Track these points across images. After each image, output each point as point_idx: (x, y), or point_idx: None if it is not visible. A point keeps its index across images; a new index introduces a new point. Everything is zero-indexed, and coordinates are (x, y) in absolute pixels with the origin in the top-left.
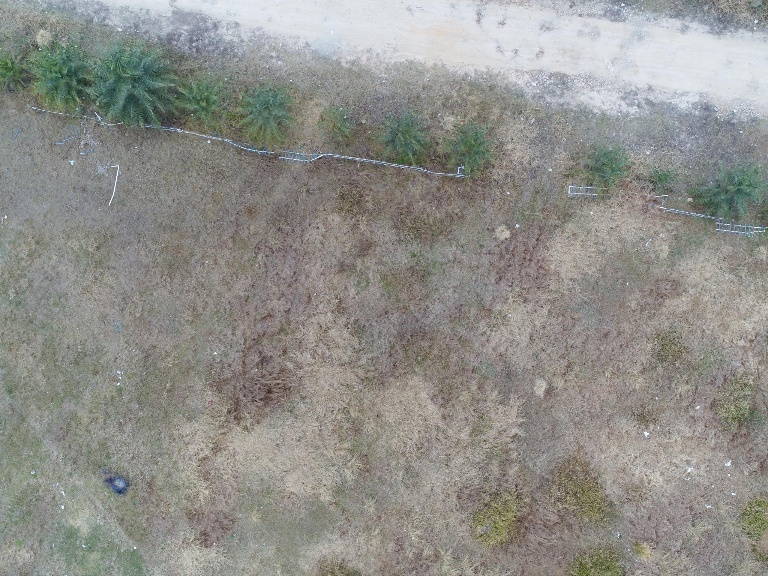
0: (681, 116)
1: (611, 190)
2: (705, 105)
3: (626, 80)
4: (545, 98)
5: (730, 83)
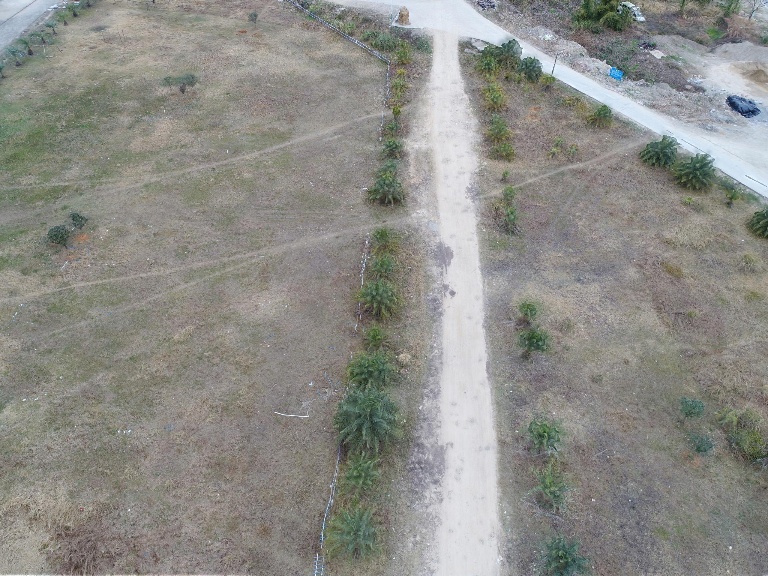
0: None
1: None
2: None
3: None
4: None
5: None
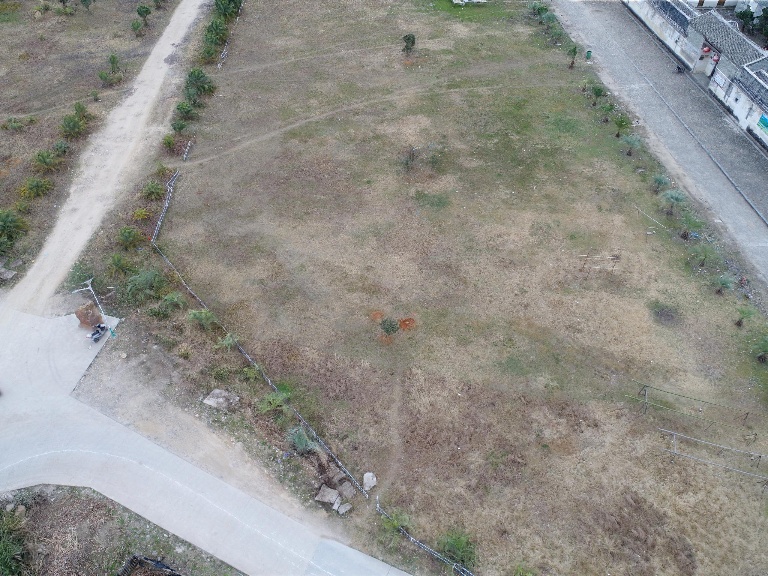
0: None
1: None
2: None
3: None
4: None
5: None
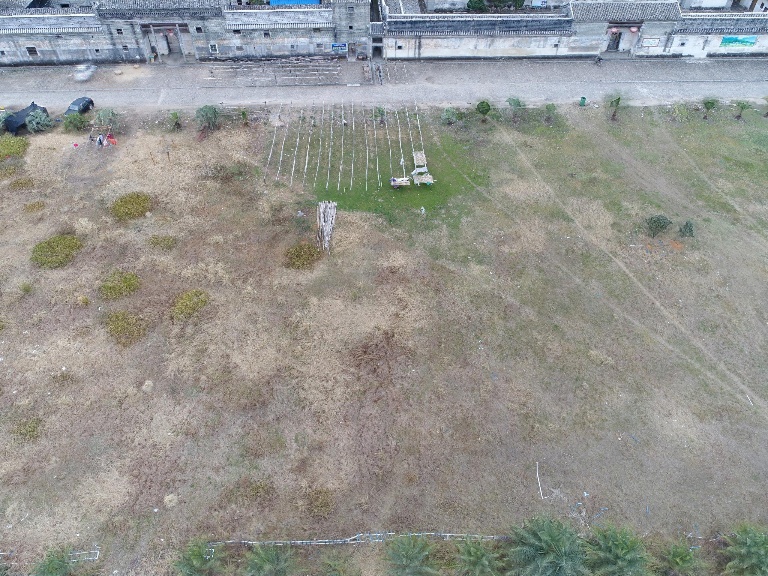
0: None
1: None
2: None
3: None
4: None
5: None
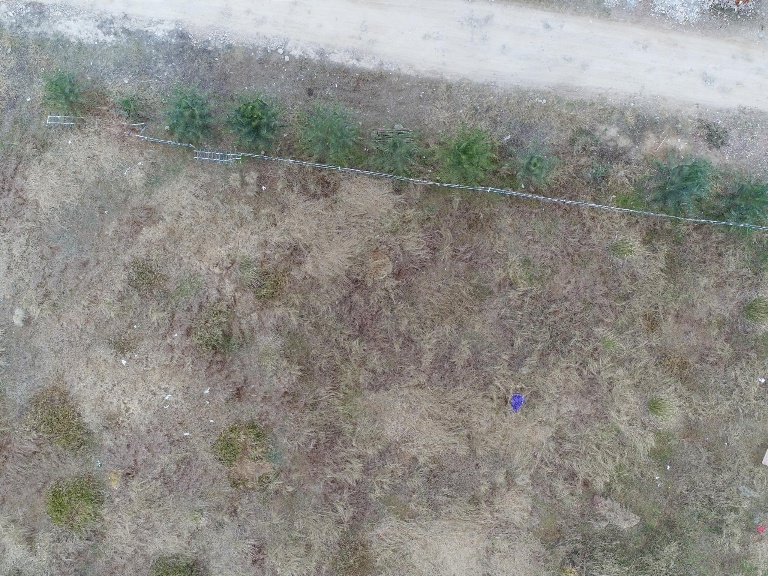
0: (157, 44)
1: (86, 119)
2: (181, 33)
3: (102, 9)
4: (22, 28)
5: (204, 10)
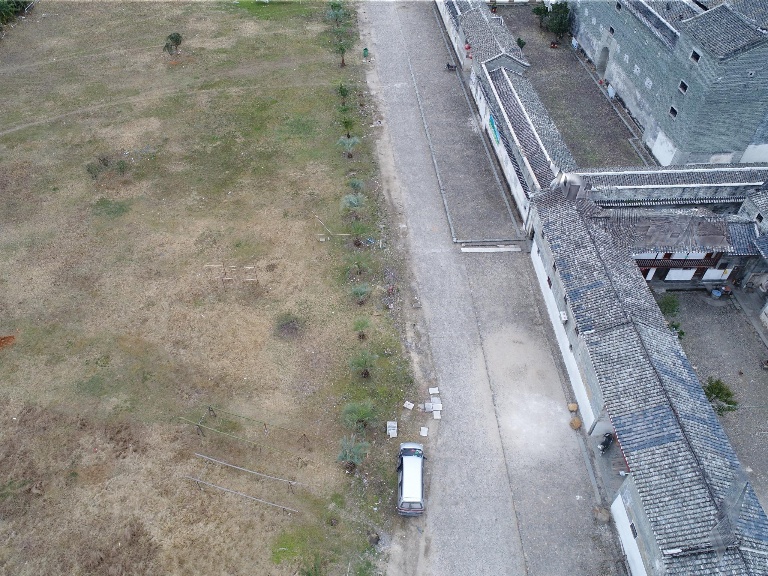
0: None
1: None
2: None
3: None
4: None
5: None
